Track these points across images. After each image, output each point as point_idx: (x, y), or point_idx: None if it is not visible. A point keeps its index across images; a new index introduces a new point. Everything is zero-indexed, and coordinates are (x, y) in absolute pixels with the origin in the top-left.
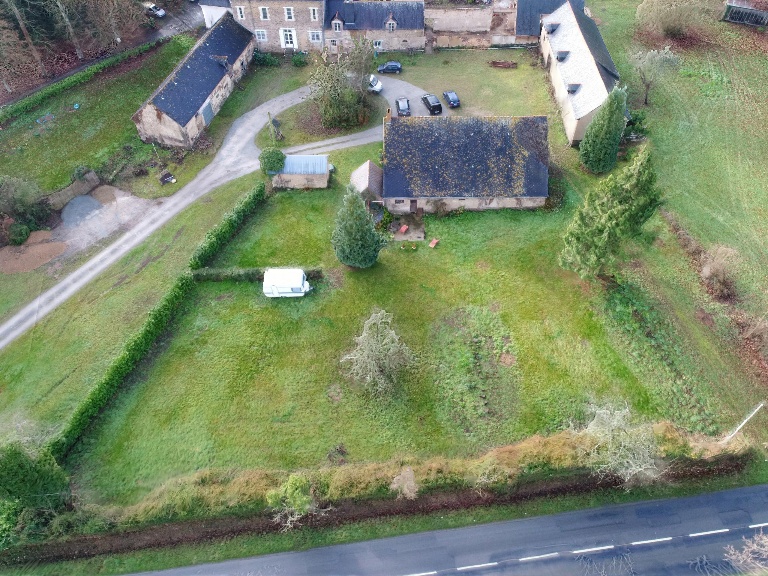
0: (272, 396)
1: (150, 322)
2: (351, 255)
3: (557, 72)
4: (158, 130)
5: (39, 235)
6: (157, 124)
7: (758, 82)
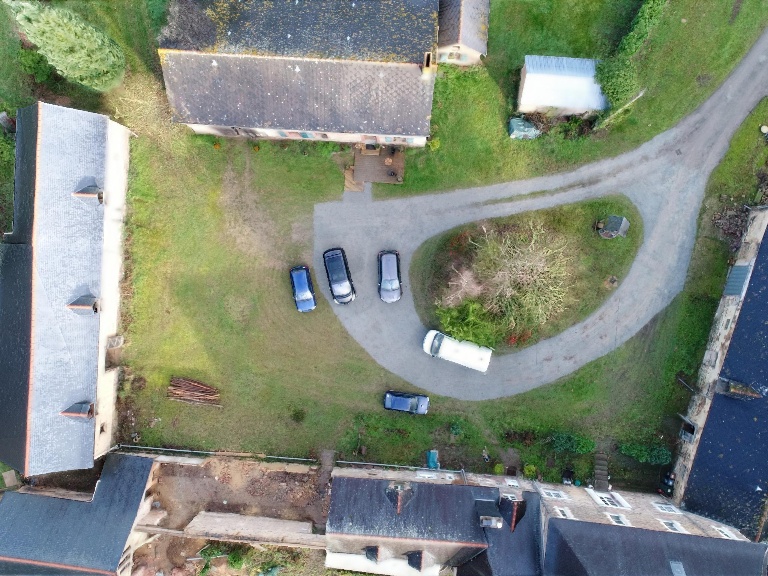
0: None
1: None
2: None
3: (106, 288)
4: None
5: None
6: None
7: None
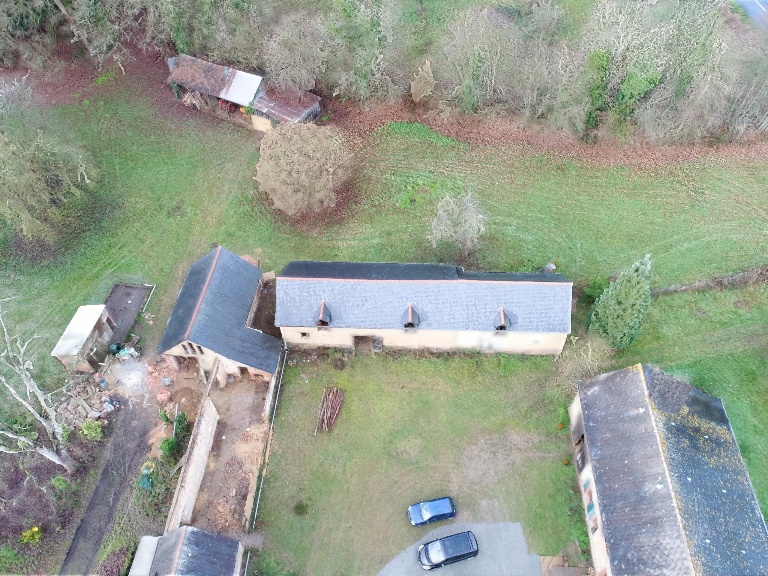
0: None
1: None
2: None
3: (424, 335)
4: None
5: None
6: None
7: (434, 151)
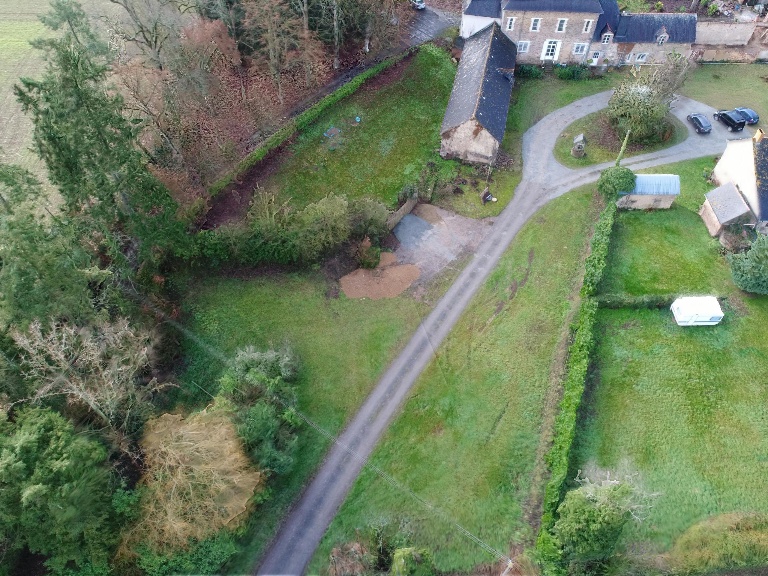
0: (743, 433)
1: (585, 354)
2: (765, 282)
3: None
4: (466, 146)
5: (386, 257)
6: (469, 140)
7: None
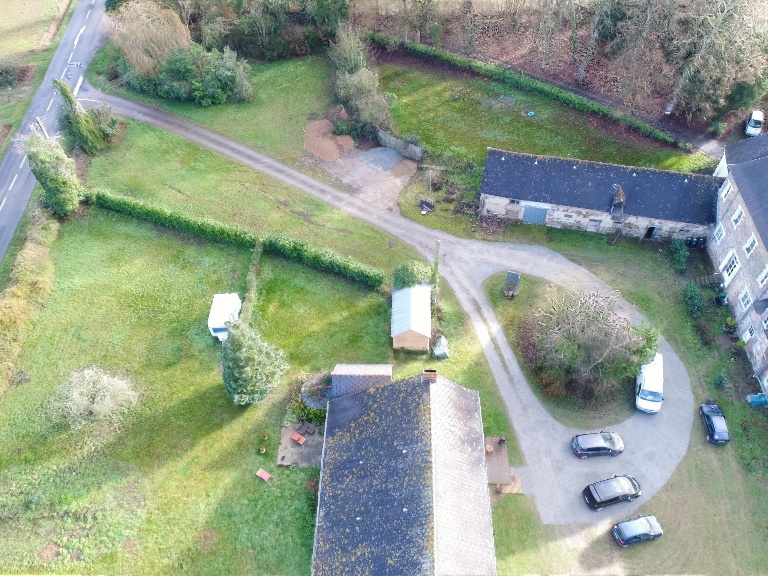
0: (104, 324)
1: None
2: None
3: None
4: None
5: (346, 141)
6: None
7: None
